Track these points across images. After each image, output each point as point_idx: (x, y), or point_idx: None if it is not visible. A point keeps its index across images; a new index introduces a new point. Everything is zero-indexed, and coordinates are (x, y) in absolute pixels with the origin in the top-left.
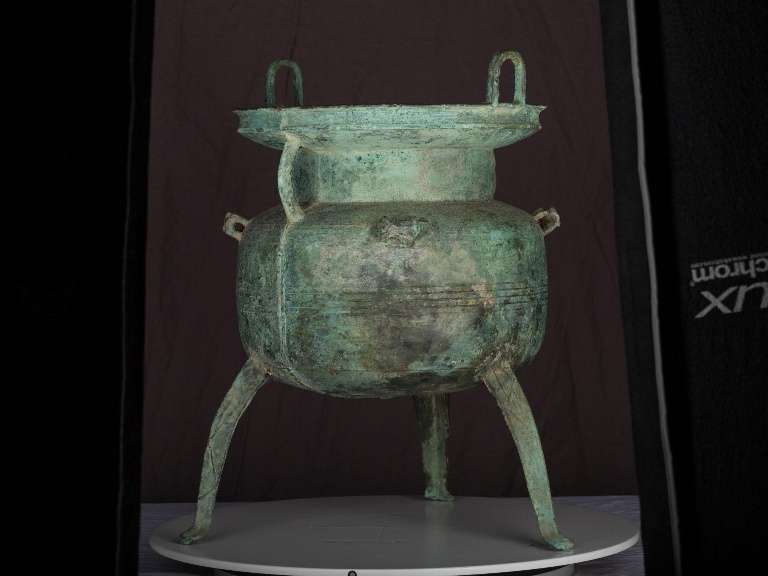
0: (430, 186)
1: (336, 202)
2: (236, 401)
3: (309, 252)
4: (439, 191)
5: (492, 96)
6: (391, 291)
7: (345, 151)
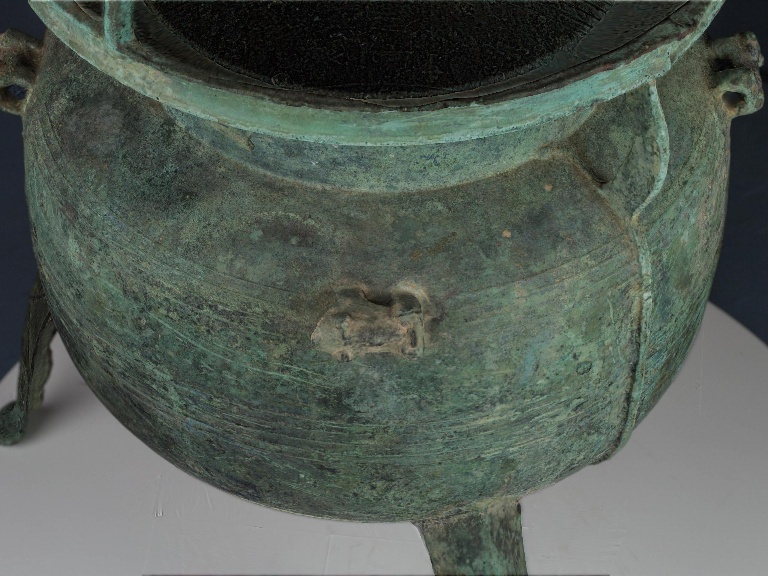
0: None
1: (589, 115)
2: None
3: (687, 244)
4: None
5: None
6: None
7: (611, 8)
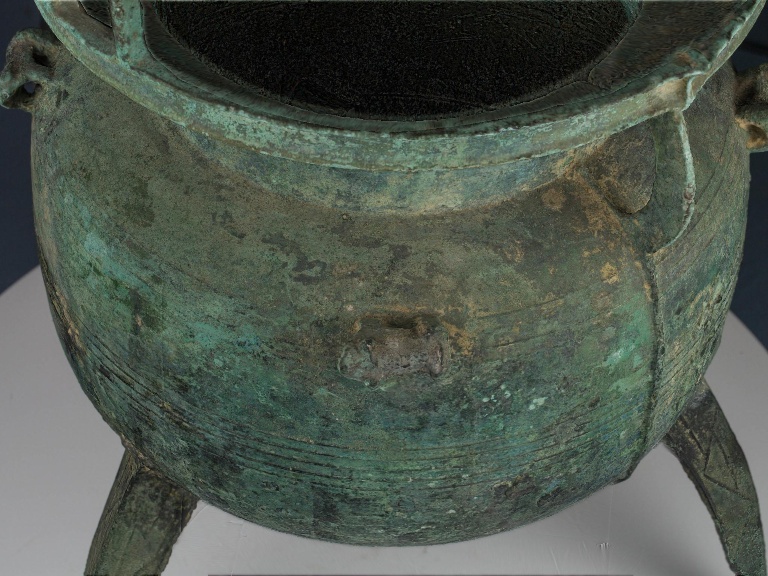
0: None
1: None
2: None
3: None
4: None
5: None
6: None
7: None
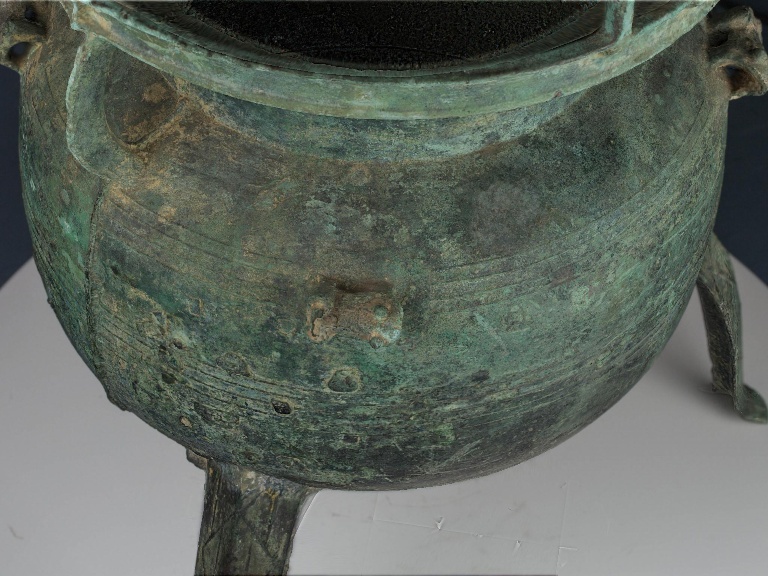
0: None
1: None
2: None
3: None
4: None
5: None
6: None
7: None
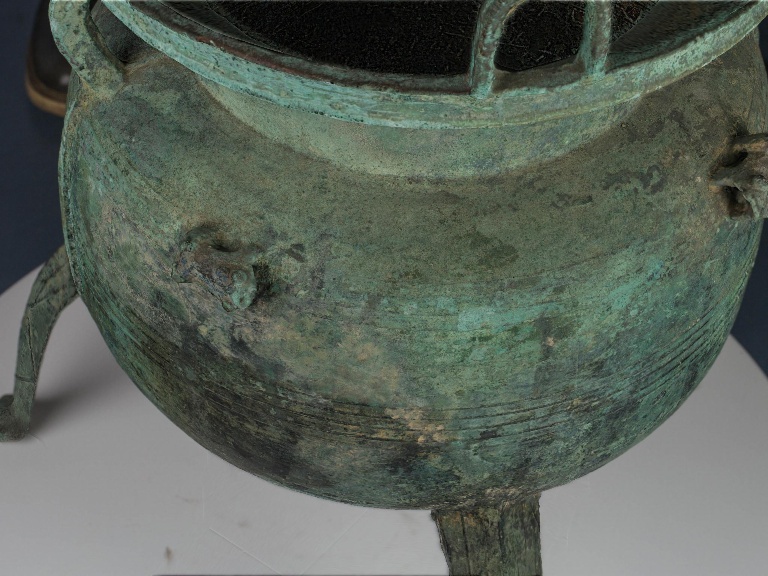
0: (373, 144)
1: (197, 77)
2: (67, 274)
3: (90, 191)
4: (396, 157)
5: (472, 78)
6: (206, 362)
7: None
